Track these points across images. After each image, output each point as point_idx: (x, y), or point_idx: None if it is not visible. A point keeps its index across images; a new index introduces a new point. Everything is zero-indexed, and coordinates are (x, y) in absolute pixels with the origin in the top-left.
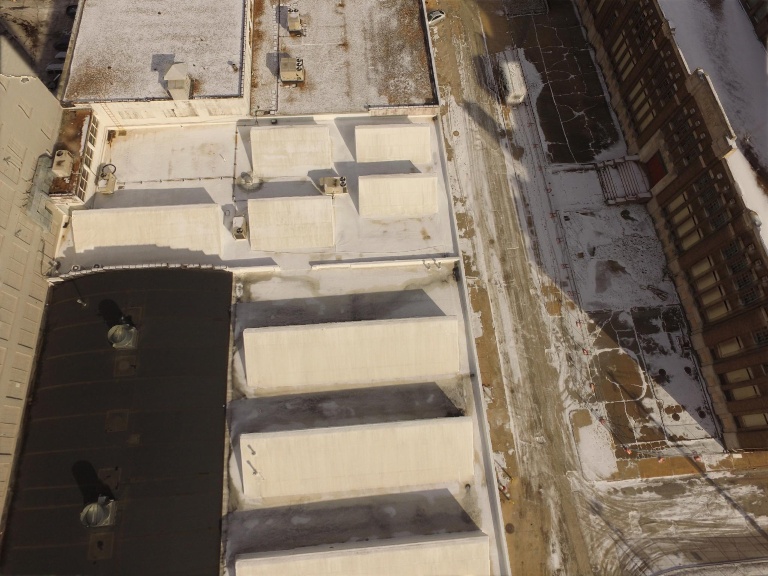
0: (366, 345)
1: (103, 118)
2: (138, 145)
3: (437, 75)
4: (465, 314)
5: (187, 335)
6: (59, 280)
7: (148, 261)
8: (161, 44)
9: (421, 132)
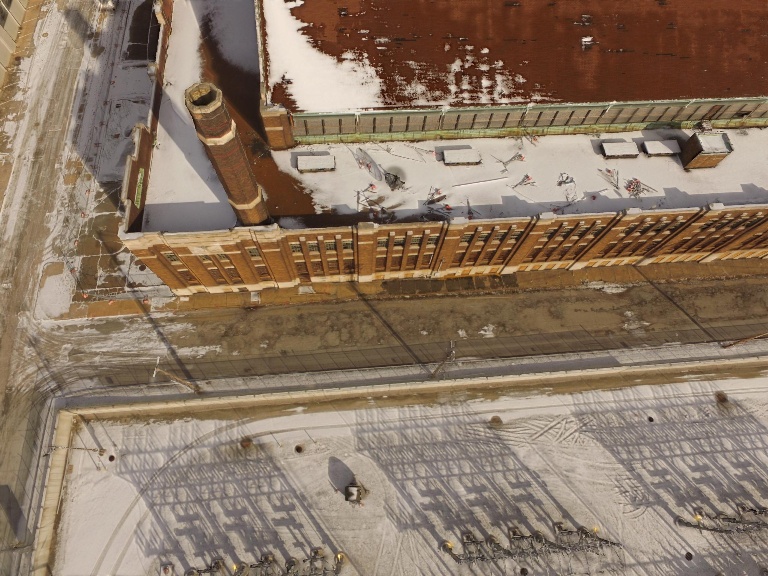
0: None
1: None
2: None
3: None
4: None
5: None
6: None
7: None
8: None
9: None
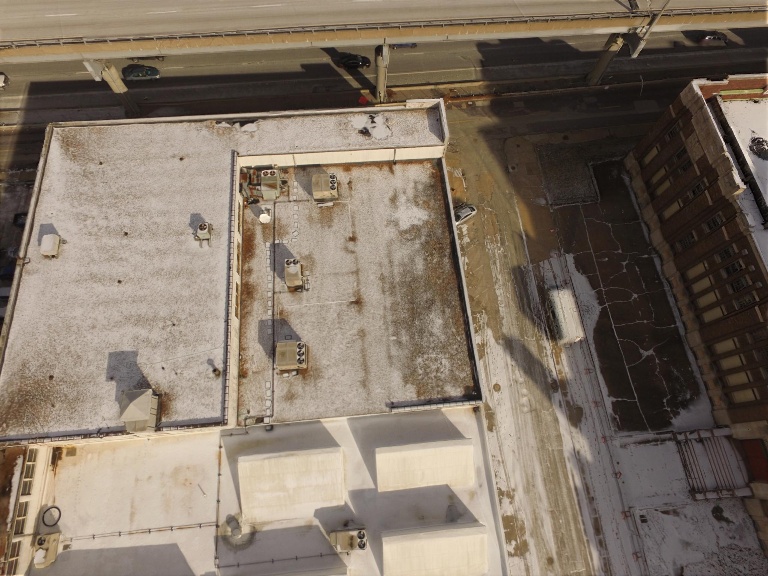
0: None
1: (43, 446)
2: (91, 472)
3: (469, 298)
4: None
5: None
6: None
7: None
8: (120, 334)
9: (462, 451)
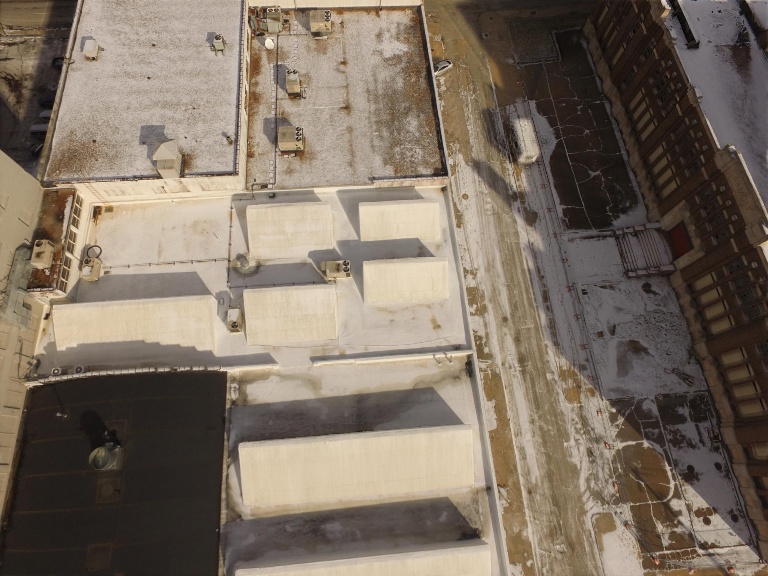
0: (373, 458)
1: (88, 196)
2: (126, 223)
3: (444, 131)
4: (479, 416)
5: (177, 450)
6: (38, 384)
7: (135, 358)
8: (150, 113)
9: (430, 208)
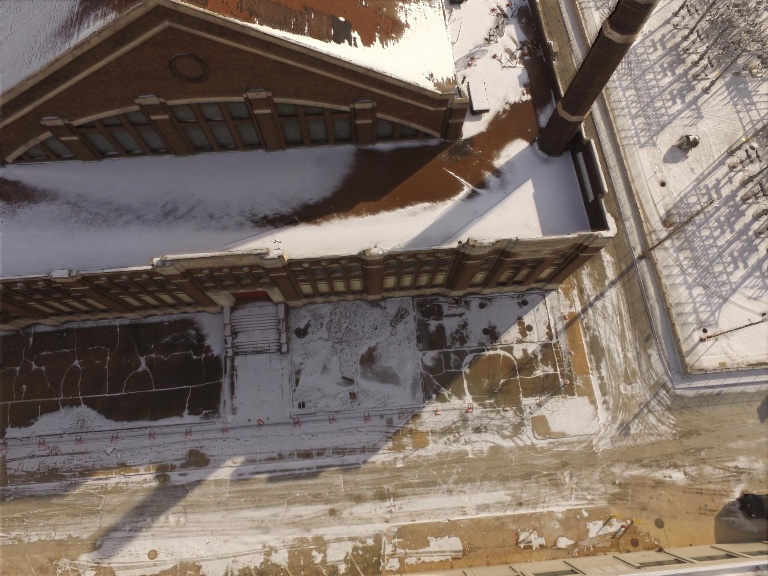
0: None
1: None
2: None
3: None
4: None
5: None
6: None
7: None
8: None
9: None
